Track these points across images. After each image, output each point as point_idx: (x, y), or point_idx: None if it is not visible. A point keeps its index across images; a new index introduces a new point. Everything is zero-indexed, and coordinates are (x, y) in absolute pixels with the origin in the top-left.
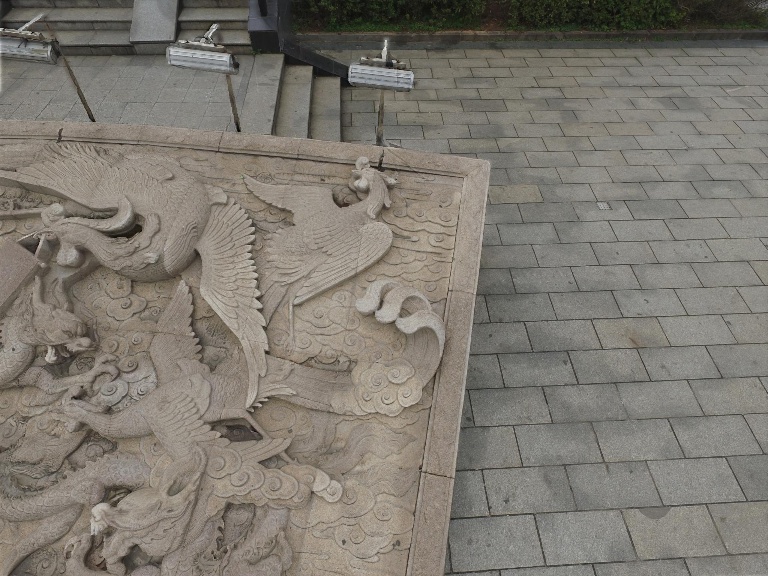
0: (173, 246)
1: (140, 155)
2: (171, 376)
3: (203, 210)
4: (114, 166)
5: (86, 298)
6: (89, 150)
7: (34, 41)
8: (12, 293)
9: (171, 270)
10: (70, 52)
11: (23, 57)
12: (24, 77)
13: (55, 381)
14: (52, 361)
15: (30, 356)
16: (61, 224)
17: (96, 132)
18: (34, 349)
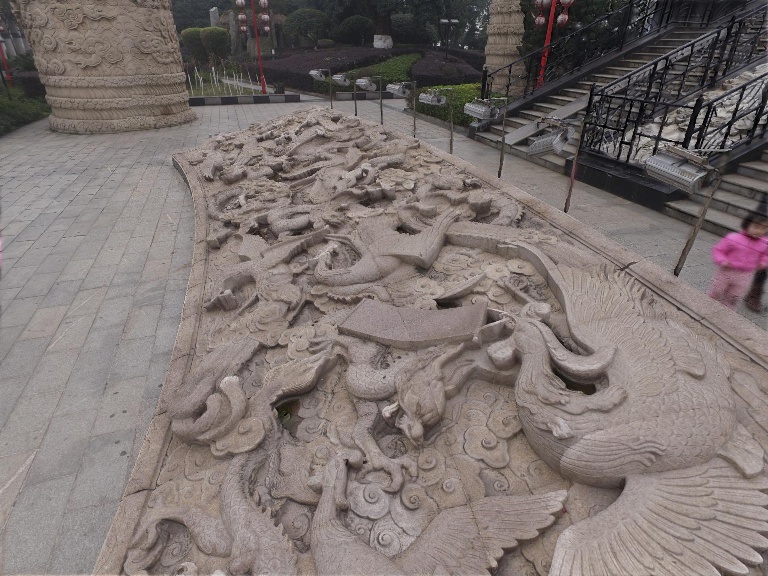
0: (600, 444)
1: (687, 330)
2: (415, 569)
3: (697, 448)
4: (643, 317)
5: (472, 400)
6: (637, 290)
7: (694, 164)
8: (436, 339)
9: (567, 466)
10: (725, 234)
11: (666, 175)
12: (660, 231)
13: (366, 432)
14: (385, 415)
15: (385, 394)
16: (530, 322)
17: (665, 283)
18: (393, 393)
